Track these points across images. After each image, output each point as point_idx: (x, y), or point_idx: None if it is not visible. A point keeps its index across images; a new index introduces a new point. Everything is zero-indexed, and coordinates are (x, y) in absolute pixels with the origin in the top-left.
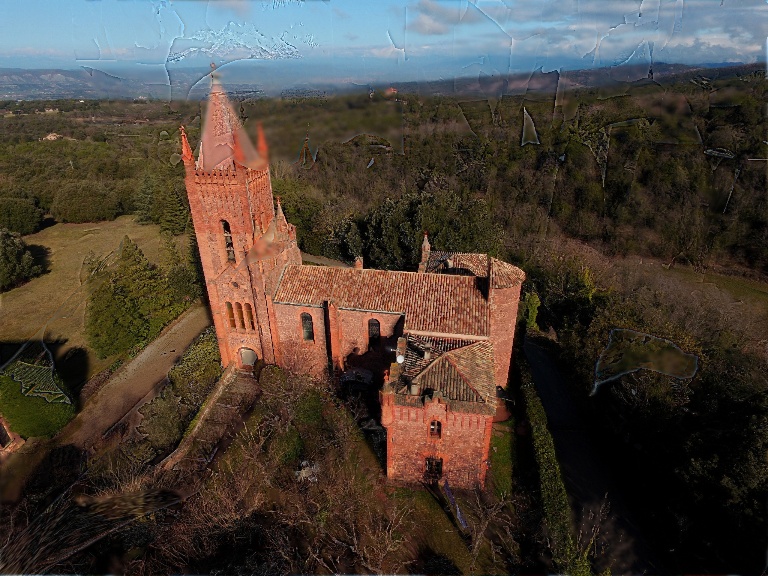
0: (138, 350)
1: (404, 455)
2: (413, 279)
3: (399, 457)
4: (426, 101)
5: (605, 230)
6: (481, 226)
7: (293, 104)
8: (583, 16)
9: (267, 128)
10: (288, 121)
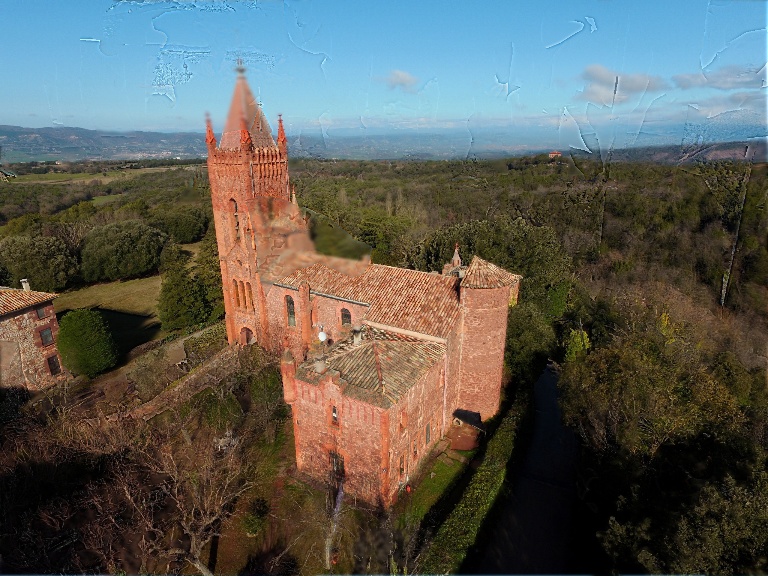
0: (195, 330)
1: (310, 444)
2: (394, 274)
3: (306, 446)
4: (519, 131)
5: (734, 287)
6: (540, 253)
7: (238, 65)
8: (710, 33)
9: (216, 88)
10: (236, 82)
